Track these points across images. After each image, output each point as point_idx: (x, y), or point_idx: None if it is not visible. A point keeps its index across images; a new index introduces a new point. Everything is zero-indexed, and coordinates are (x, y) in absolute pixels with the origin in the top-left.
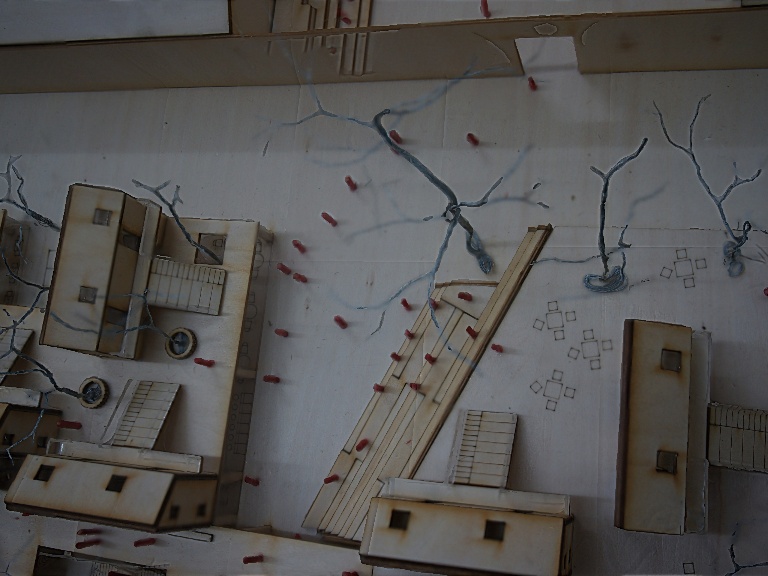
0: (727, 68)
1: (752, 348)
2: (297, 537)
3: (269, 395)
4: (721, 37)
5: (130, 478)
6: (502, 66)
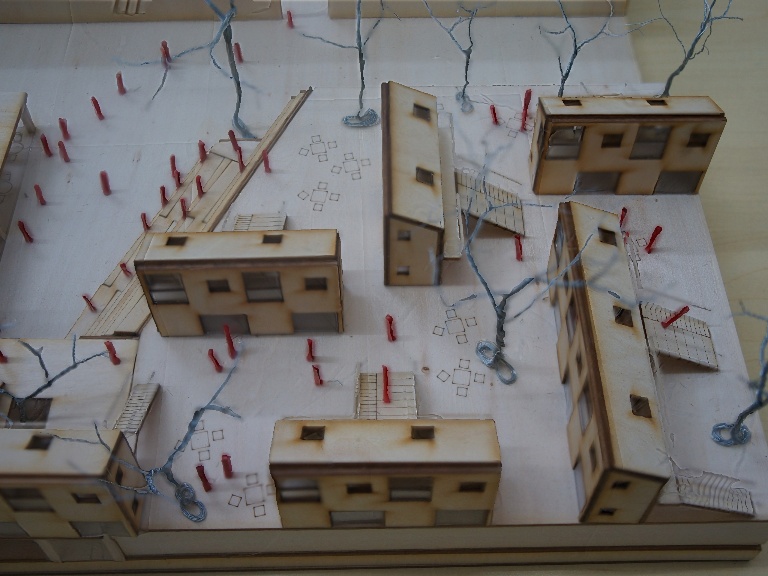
0: (446, 16)
1: (486, 157)
2: None
3: (20, 254)
4: None
5: None
6: (264, 10)
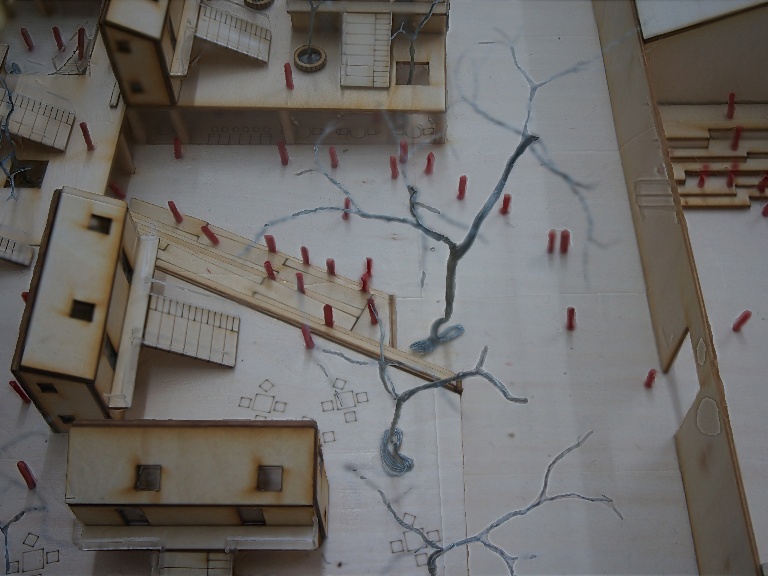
0: None
1: None
2: (122, 195)
3: (269, 158)
4: (730, 568)
5: (156, 4)
6: (669, 345)
